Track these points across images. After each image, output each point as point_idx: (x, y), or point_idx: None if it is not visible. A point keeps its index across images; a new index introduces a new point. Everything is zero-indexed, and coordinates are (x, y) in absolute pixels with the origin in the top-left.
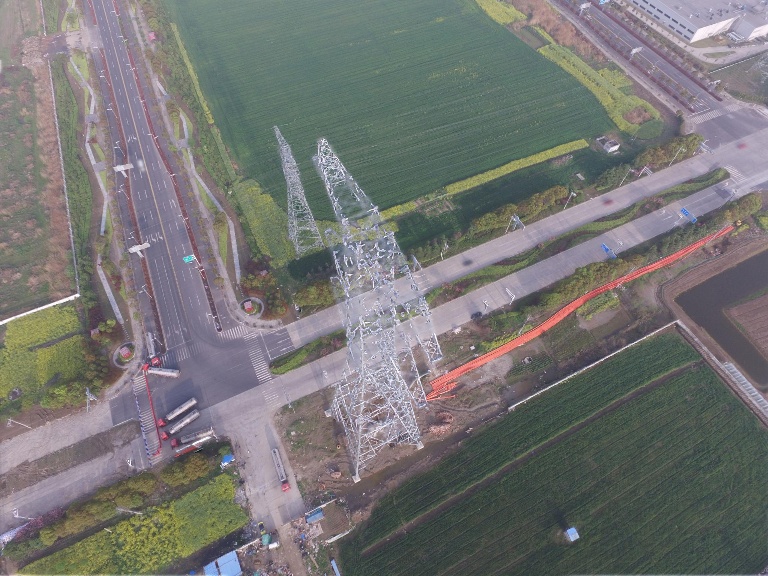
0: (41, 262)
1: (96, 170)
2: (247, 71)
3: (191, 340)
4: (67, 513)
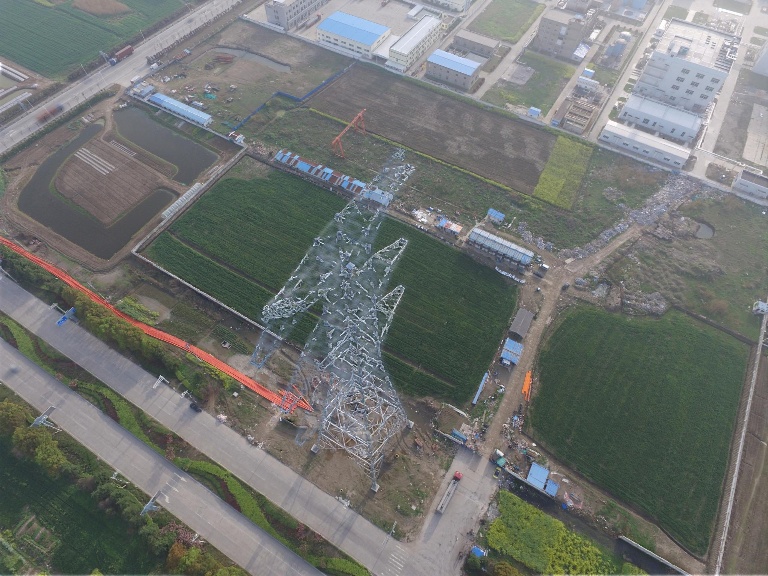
0: None
1: None
2: None
3: None
4: None
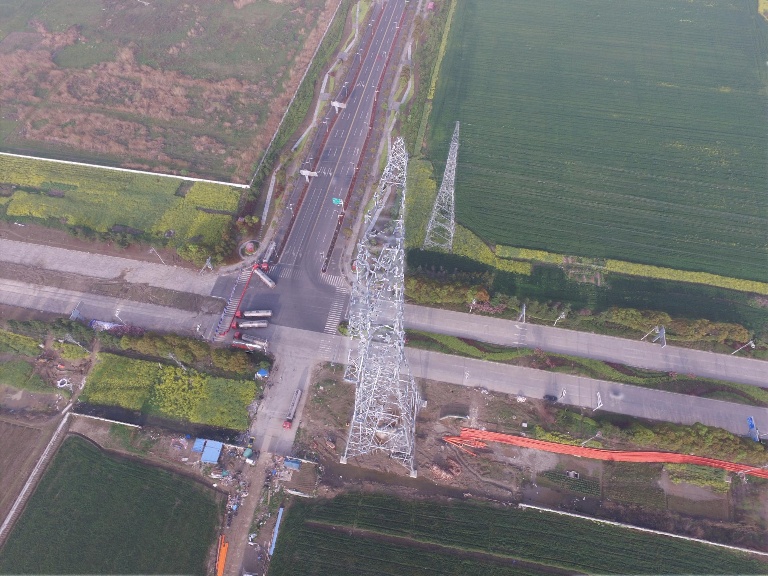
0: (242, 149)
1: (320, 98)
2: (490, 66)
3: (299, 266)
4: (144, 335)
